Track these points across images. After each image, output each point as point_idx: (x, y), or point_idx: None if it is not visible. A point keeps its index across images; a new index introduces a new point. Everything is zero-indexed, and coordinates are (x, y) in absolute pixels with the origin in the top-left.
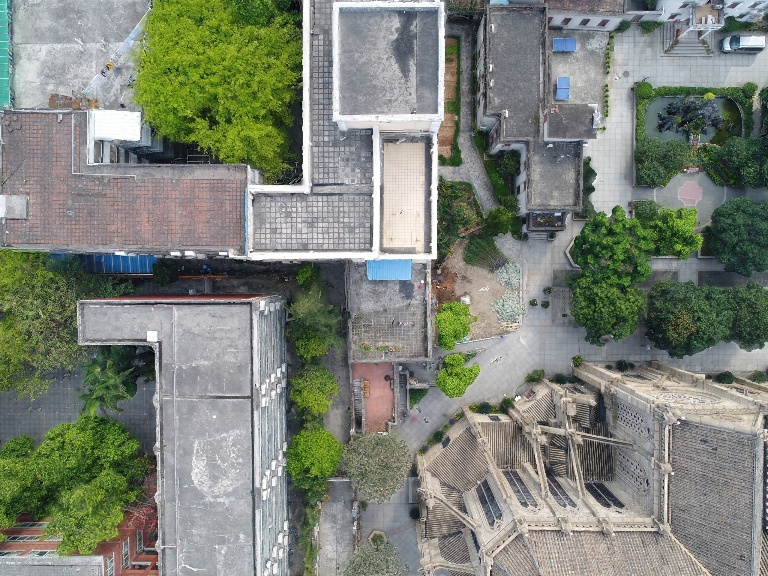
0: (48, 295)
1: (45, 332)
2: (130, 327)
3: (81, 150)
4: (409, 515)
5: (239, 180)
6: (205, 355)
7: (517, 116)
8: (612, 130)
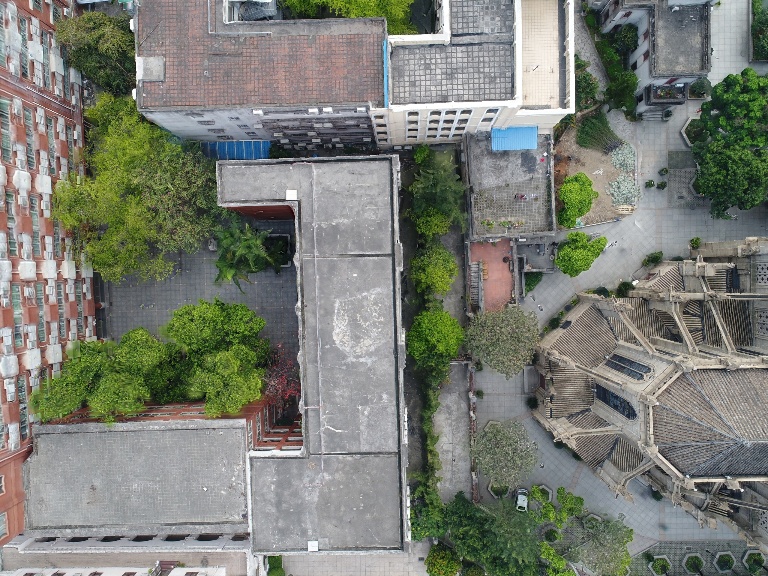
0: (175, 171)
1: (171, 209)
2: (269, 187)
3: (216, 10)
4: (525, 405)
5: (376, 34)
6: (345, 213)
7: None
8: (727, 5)
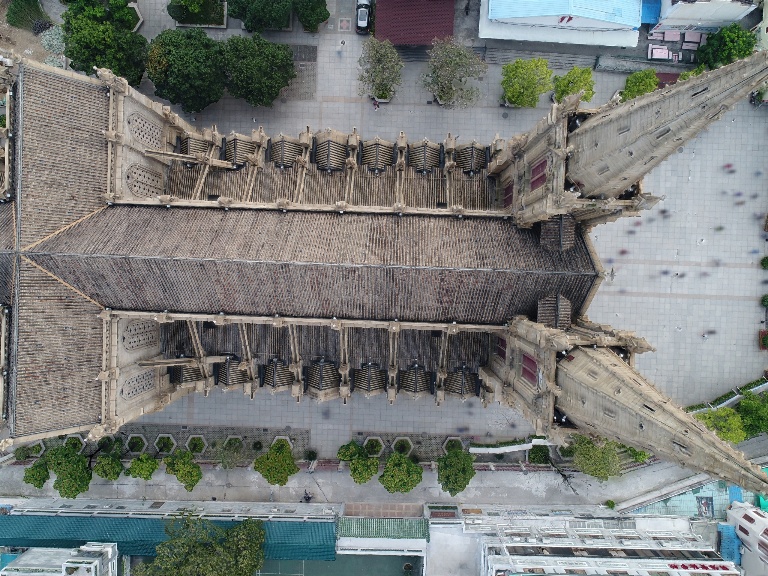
0: None
1: None
2: None
3: None
4: None
5: None
6: None
7: None
8: None
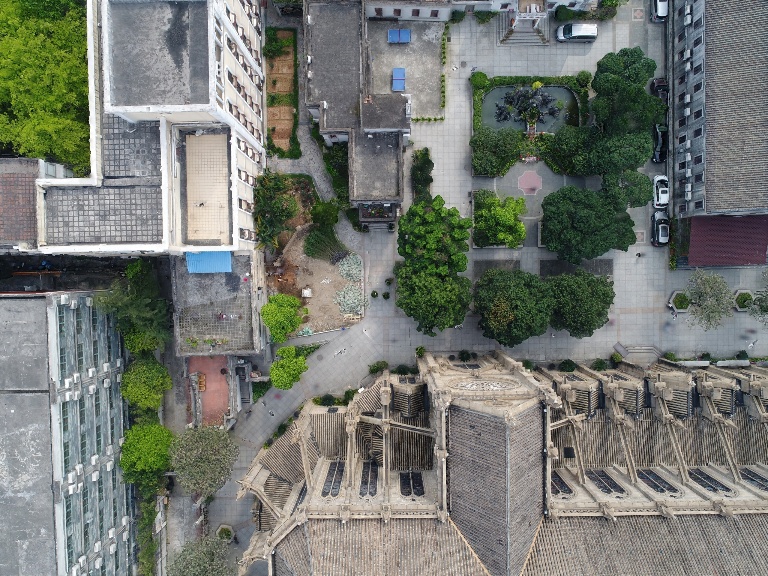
0: None
1: None
2: None
3: None
4: None
5: (32, 174)
6: (2, 350)
7: (338, 107)
8: (451, 120)
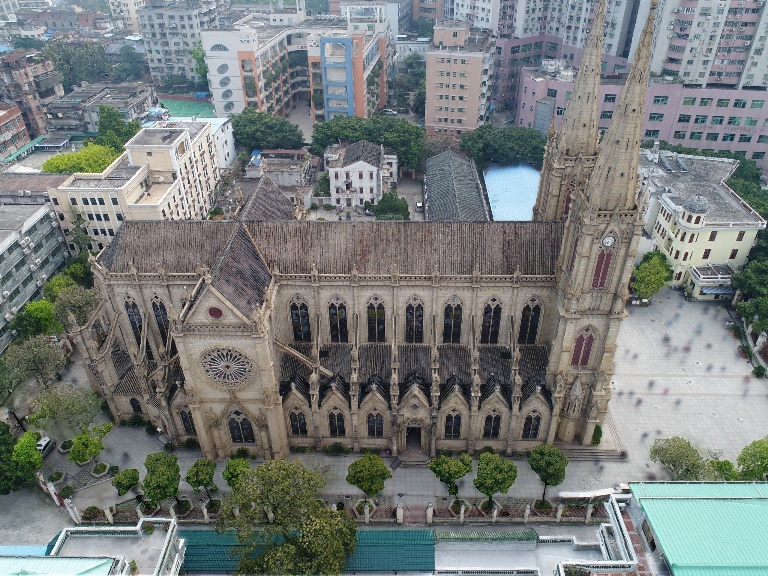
0: None
1: None
2: None
3: None
4: (91, 387)
5: None
6: None
7: None
8: None
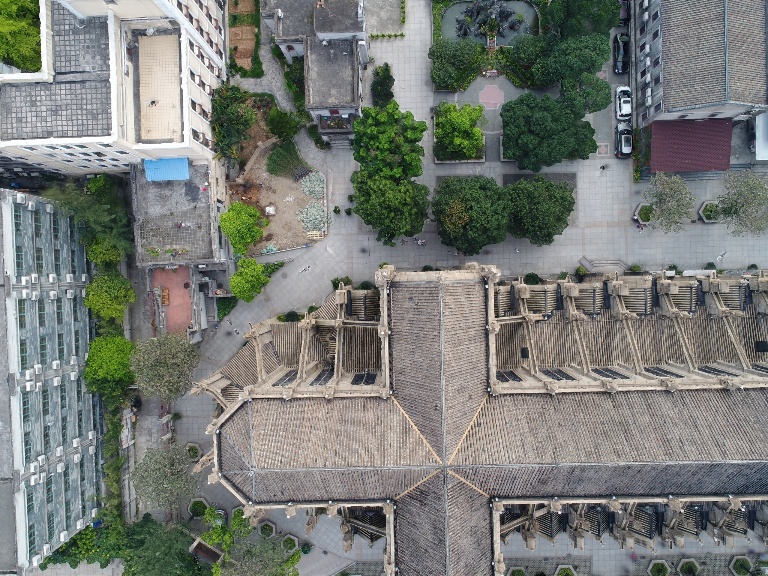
0: None
1: None
2: None
3: None
4: None
5: None
6: None
7: (293, 16)
8: (411, 37)
